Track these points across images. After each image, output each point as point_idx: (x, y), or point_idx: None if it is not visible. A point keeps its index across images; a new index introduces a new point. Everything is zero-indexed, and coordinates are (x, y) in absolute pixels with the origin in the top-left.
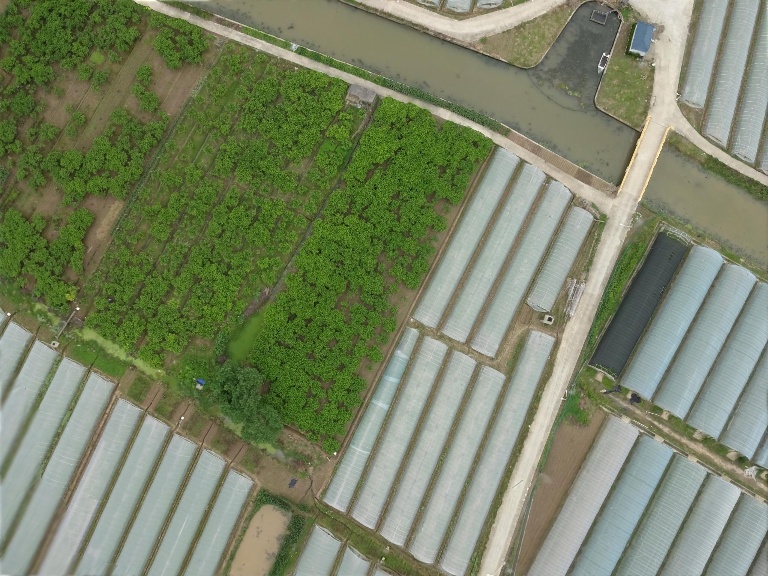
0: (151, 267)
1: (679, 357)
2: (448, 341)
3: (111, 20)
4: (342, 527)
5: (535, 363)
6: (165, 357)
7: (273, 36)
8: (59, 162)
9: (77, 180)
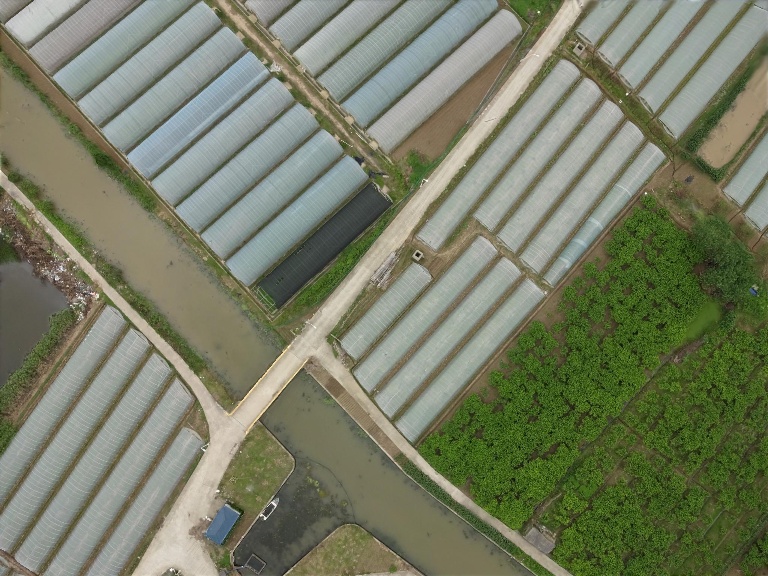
0: None
1: (305, 185)
2: (517, 263)
3: None
4: (654, 131)
5: (444, 219)
6: None
7: None
8: None
9: None
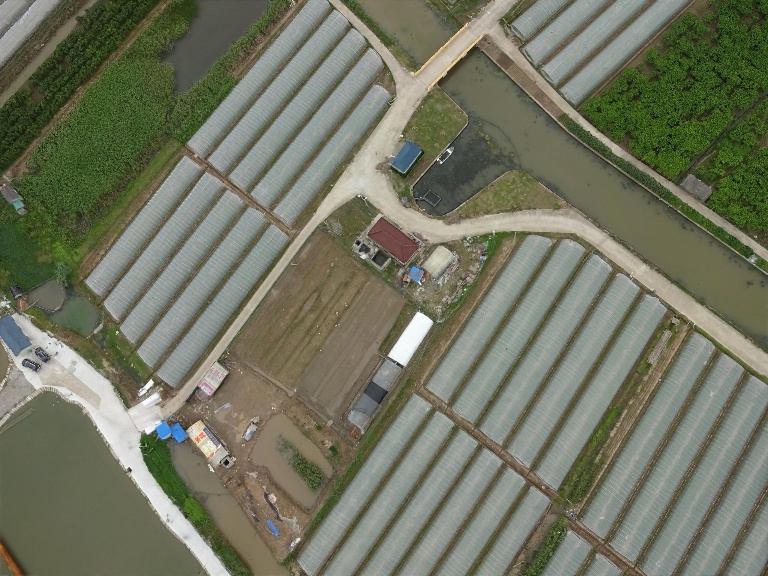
0: None
1: None
2: None
3: None
4: None
5: None
6: None
7: None
8: None
9: None
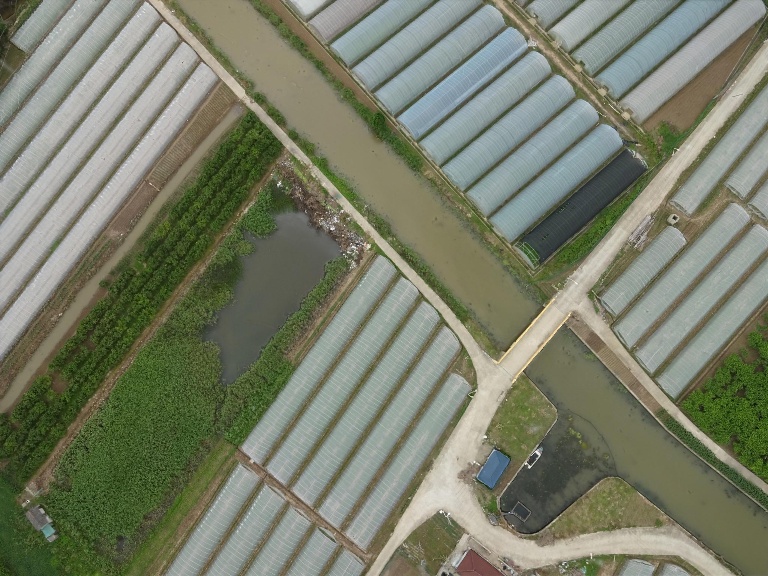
0: None
1: (564, 150)
2: None
3: None
4: None
5: (699, 185)
6: None
7: None
8: None
9: None
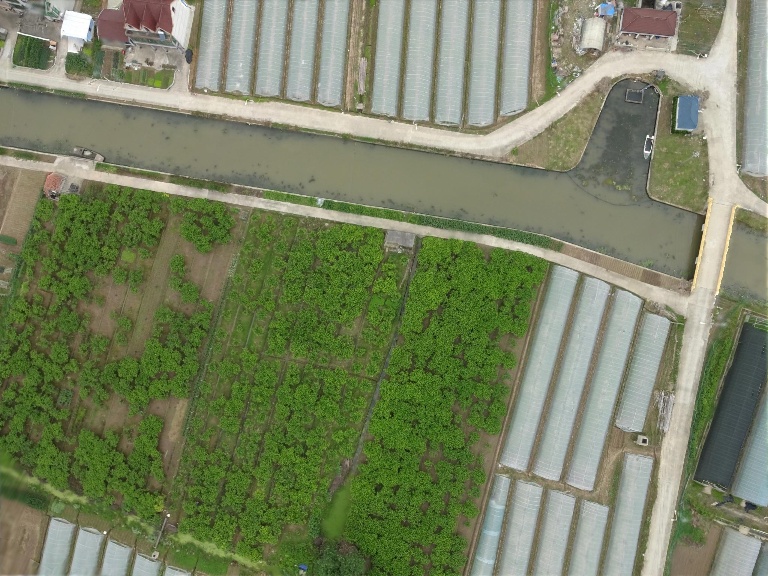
0: (229, 462)
1: None
2: (541, 481)
3: (133, 216)
4: None
5: (637, 490)
6: (263, 549)
7: (296, 194)
8: (117, 373)
9: (138, 388)
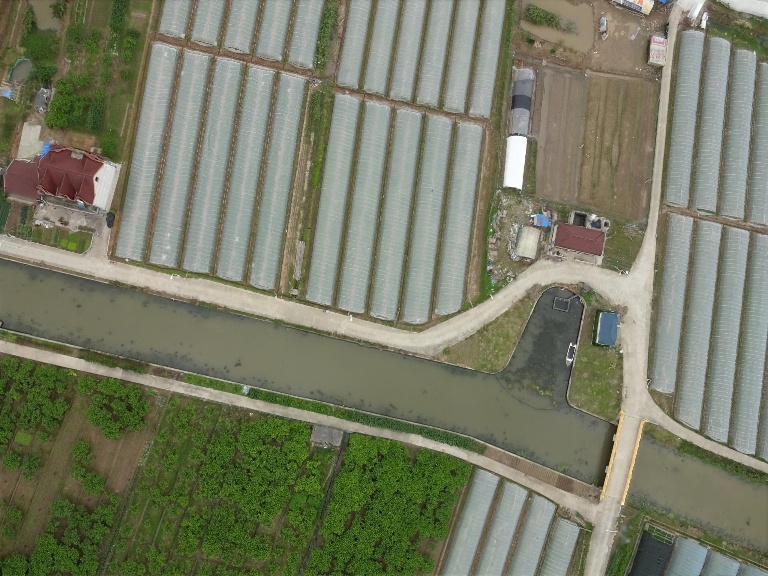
0: None
1: None
2: None
3: (32, 396)
4: None
5: None
6: None
7: (220, 380)
8: (0, 572)
9: None
